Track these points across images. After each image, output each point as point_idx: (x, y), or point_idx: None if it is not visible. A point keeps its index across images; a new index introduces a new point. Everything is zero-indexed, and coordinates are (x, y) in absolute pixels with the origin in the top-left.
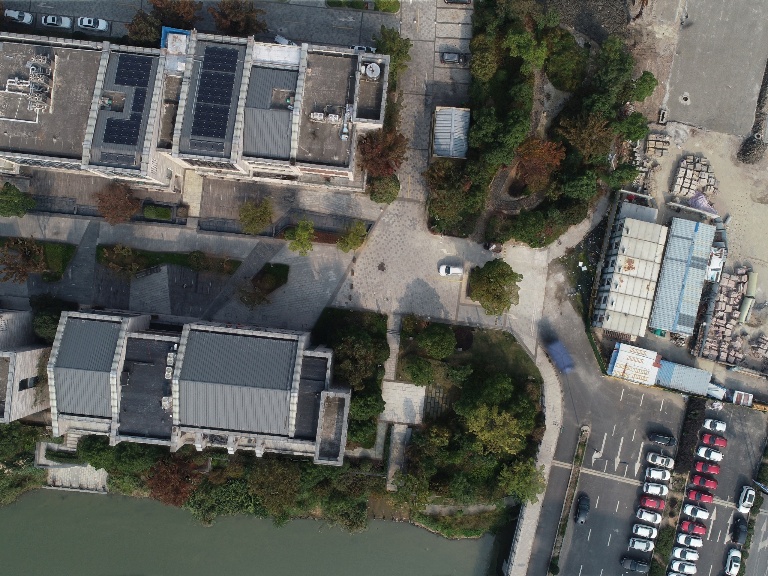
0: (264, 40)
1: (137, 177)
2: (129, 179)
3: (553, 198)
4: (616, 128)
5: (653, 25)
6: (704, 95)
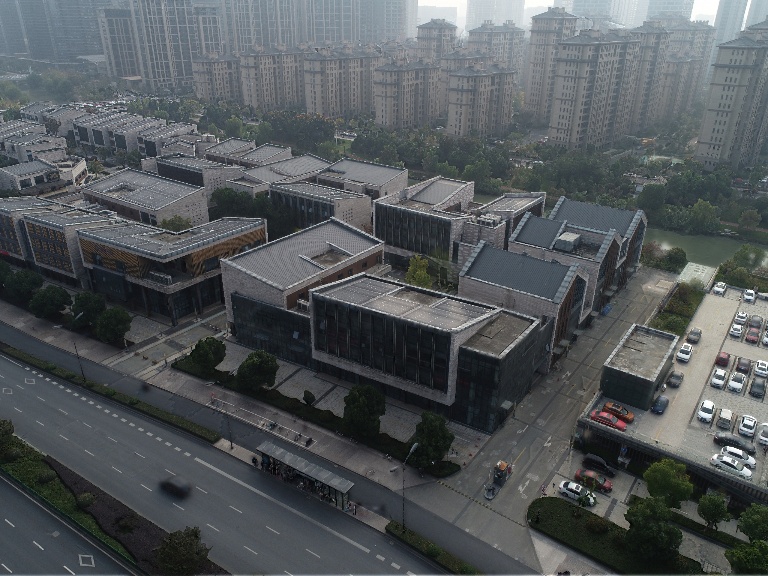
0: None
1: None
2: None
3: None
4: None
5: None
6: None
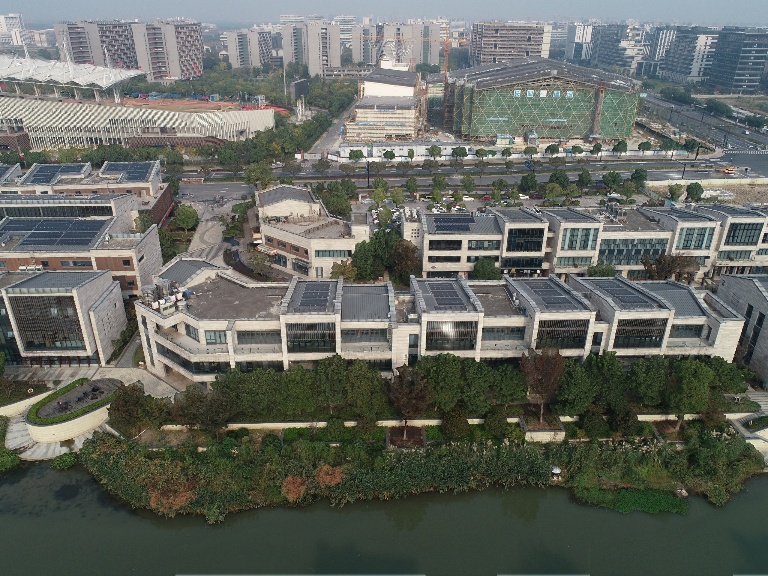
0: None
1: (694, 249)
2: (687, 254)
3: None
4: None
5: None
6: None
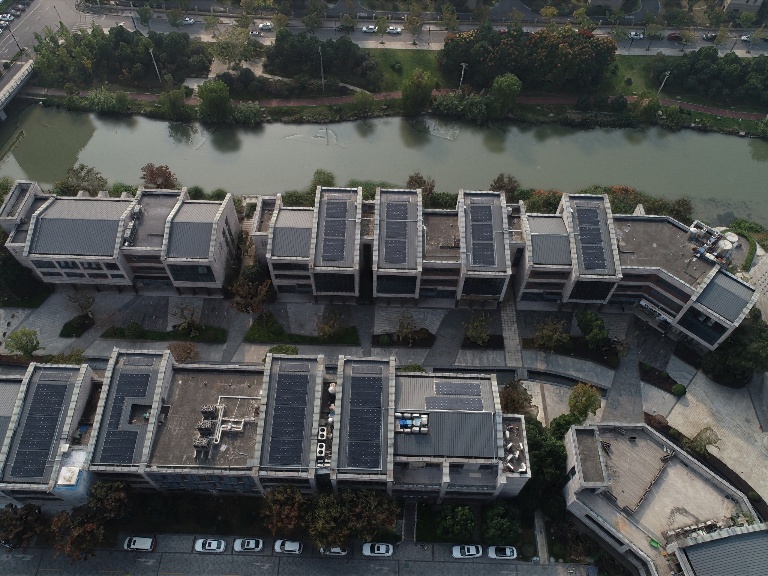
0: (29, 544)
1: None
2: None
3: None
4: None
5: None
6: None
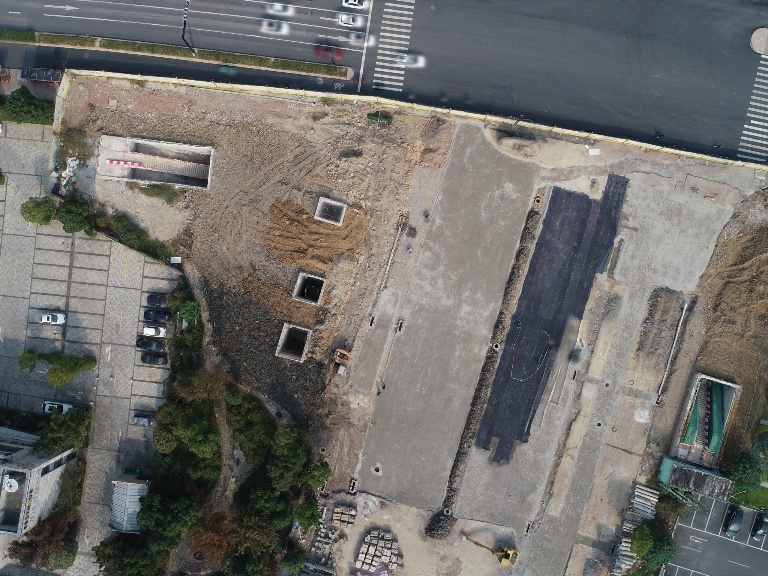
0: None
1: None
2: None
3: (226, 575)
4: (278, 525)
5: (349, 395)
6: (396, 467)
